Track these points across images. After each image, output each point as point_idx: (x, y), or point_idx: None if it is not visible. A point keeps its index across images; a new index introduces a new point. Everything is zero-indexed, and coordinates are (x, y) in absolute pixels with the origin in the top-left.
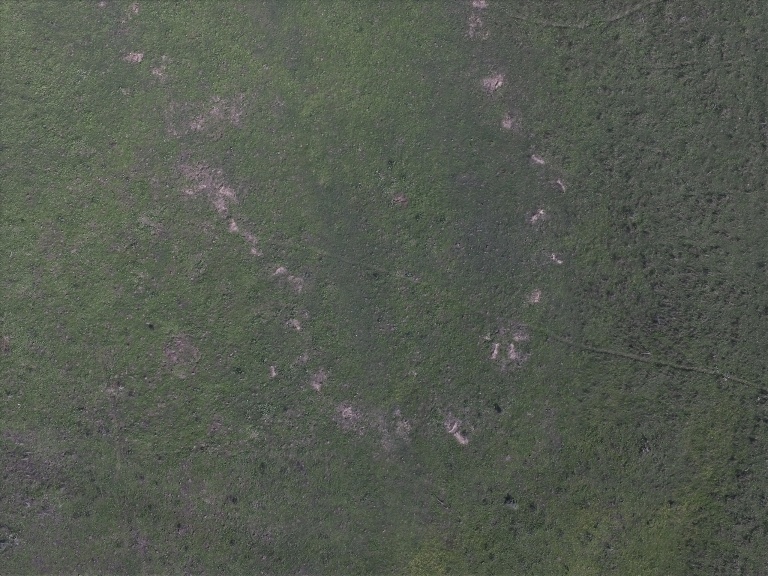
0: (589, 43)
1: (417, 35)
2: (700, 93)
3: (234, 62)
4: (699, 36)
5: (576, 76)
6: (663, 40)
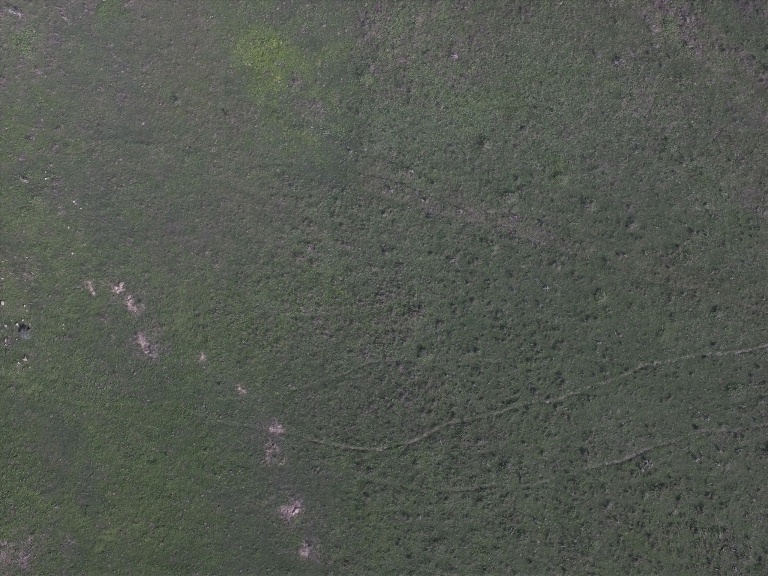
0: (387, 467)
1: (212, 463)
2: (498, 517)
3: (22, 504)
4: (497, 459)
5: (374, 500)
6: (461, 462)
